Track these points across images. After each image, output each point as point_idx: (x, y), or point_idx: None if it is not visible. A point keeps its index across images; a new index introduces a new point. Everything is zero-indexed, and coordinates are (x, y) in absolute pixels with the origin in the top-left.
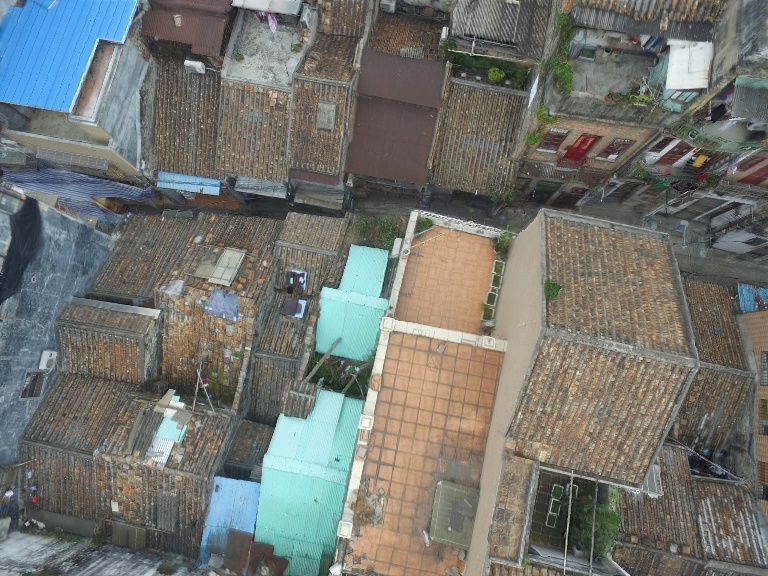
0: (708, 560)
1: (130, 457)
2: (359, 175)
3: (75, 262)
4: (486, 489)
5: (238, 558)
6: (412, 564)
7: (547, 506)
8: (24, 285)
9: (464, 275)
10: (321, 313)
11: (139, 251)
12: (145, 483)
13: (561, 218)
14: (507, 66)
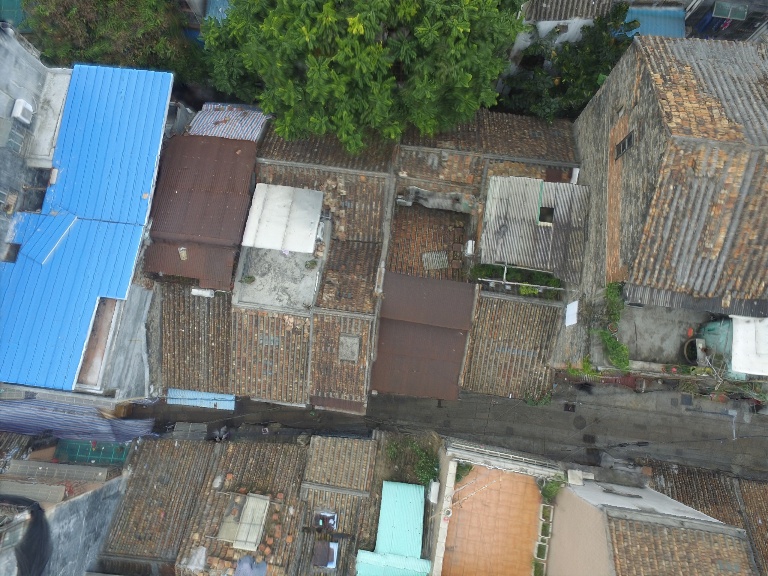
0: None
1: None
2: None
3: (86, 535)
4: None
5: None
6: None
7: None
8: None
9: (509, 521)
10: (358, 575)
11: (153, 491)
12: None
13: (625, 517)
14: (539, 277)
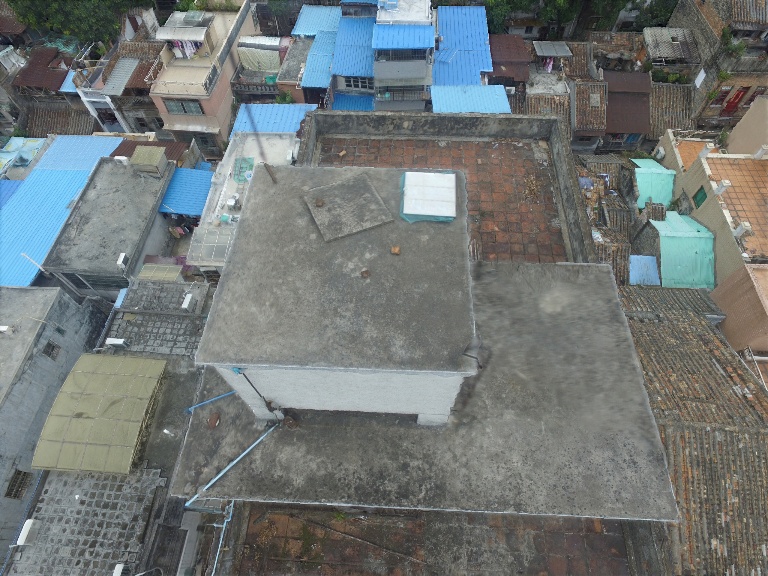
0: None
1: None
2: None
3: None
4: None
5: None
6: None
7: None
8: None
9: None
10: (637, 182)
11: None
12: None
13: None
14: None
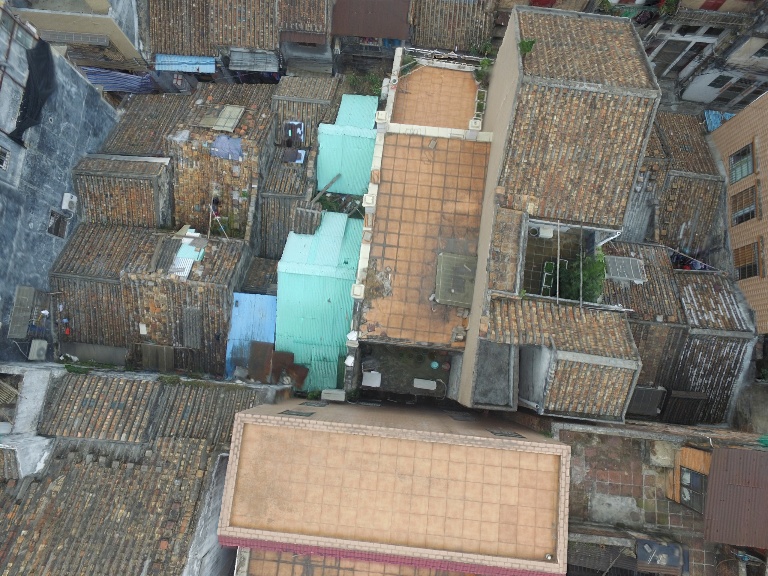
0: (692, 328)
1: (154, 273)
2: (345, 48)
3: (86, 120)
4: (482, 247)
5: (261, 367)
6: (421, 327)
7: (541, 282)
8: (43, 122)
9: (450, 106)
10: (320, 149)
11: (144, 121)
12: (170, 300)
13: None
14: None
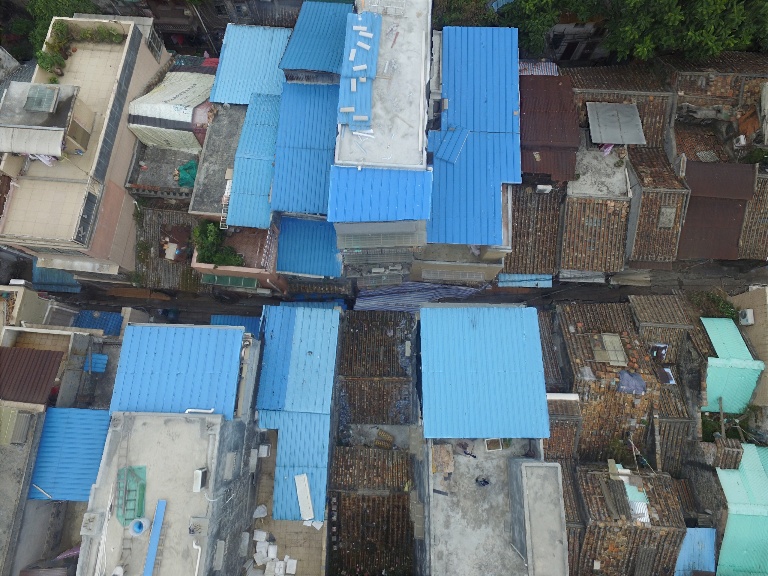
0: None
1: (621, 521)
2: None
3: None
4: None
5: None
6: None
7: None
8: None
9: None
10: (707, 379)
11: None
12: (629, 541)
13: None
14: None
